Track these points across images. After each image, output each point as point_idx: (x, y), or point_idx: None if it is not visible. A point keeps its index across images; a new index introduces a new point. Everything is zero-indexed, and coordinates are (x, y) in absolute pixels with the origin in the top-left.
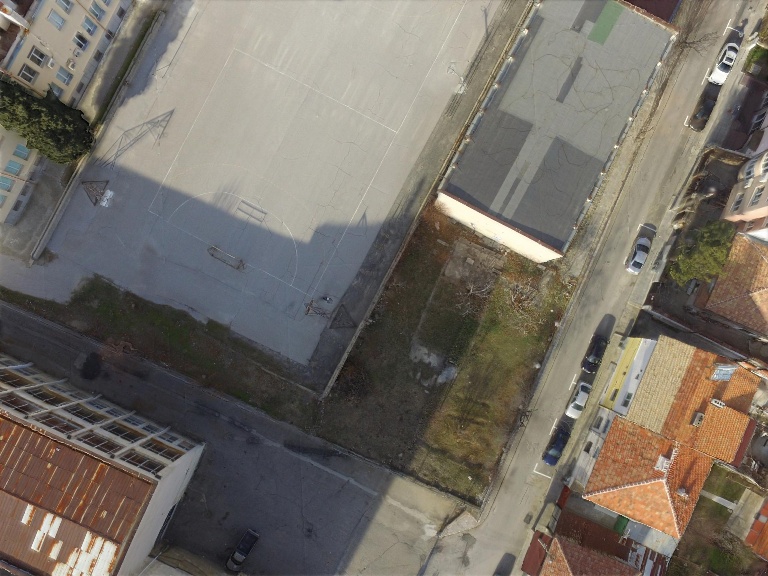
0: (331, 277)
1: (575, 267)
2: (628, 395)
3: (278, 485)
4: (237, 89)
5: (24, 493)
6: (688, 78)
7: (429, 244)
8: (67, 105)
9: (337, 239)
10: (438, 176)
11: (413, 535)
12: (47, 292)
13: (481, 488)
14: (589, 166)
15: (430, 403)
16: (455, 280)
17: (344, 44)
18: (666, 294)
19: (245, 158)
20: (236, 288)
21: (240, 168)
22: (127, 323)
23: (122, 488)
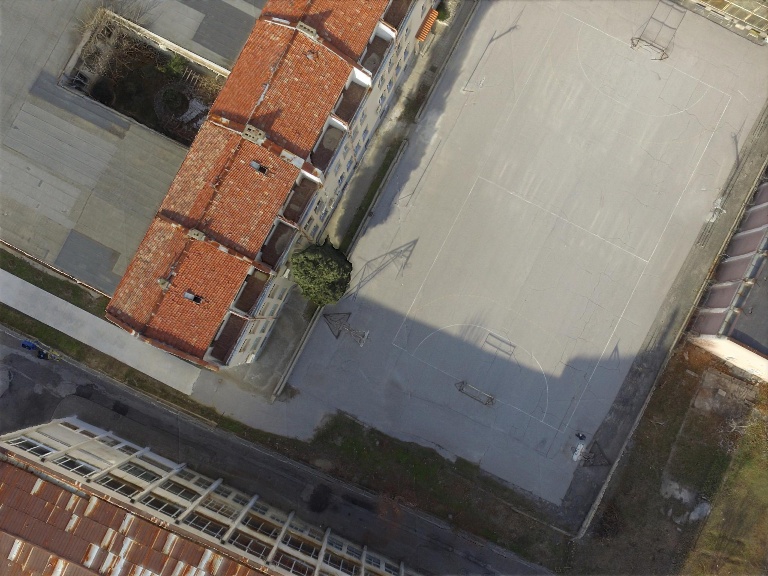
0: (583, 412)
1: None
2: None
3: None
4: (482, 218)
5: None
6: None
7: (677, 374)
8: (316, 239)
9: (589, 373)
10: (692, 307)
11: None
12: (289, 429)
13: None
14: None
15: (683, 541)
16: (705, 412)
17: (591, 172)
18: None
19: (492, 289)
20: (485, 424)
21: (487, 300)
22: (371, 461)
23: None
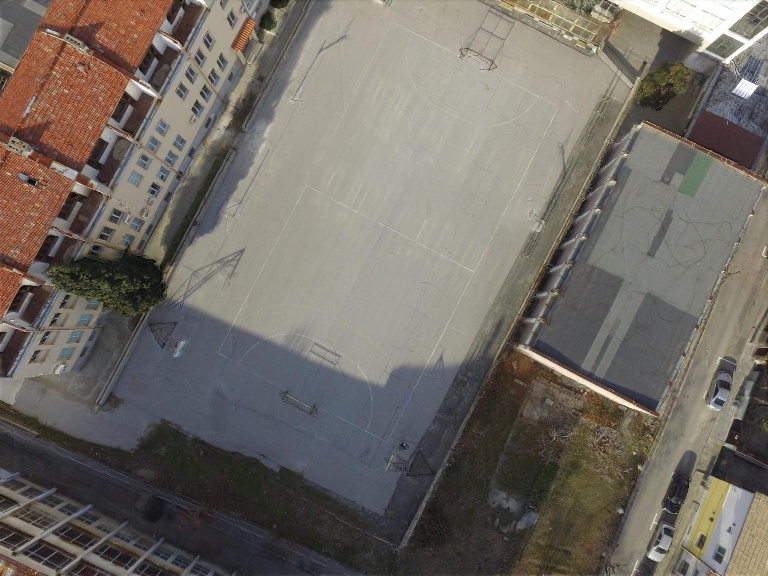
0: (407, 422)
1: None
2: (719, 548)
3: None
4: (309, 228)
5: None
6: (765, 208)
7: (506, 384)
8: (137, 249)
9: (413, 382)
10: (517, 317)
11: None
12: (112, 439)
13: None
14: (682, 322)
15: (509, 551)
16: (533, 421)
17: (419, 181)
18: (748, 430)
19: (318, 299)
20: (309, 434)
21: (313, 309)
22: (195, 471)
23: None
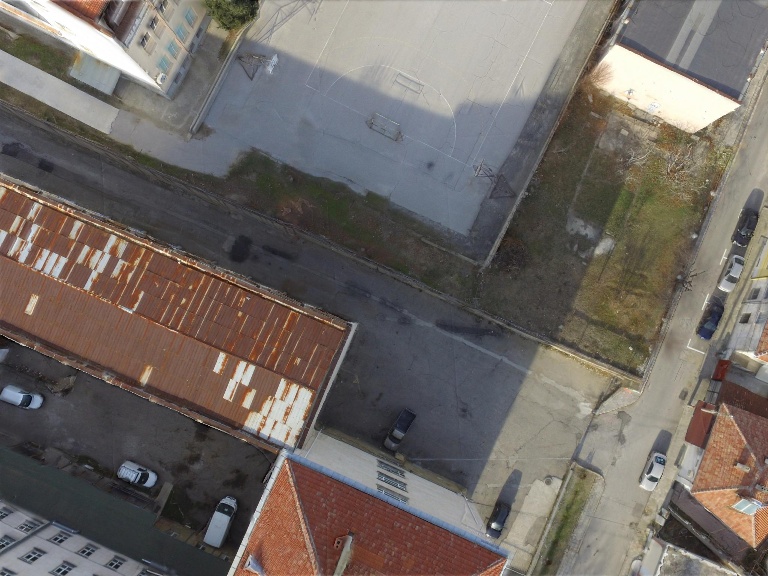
0: (490, 147)
1: (729, 136)
2: None
3: (431, 365)
4: None
5: (216, 342)
6: None
7: (582, 117)
8: None
9: (495, 110)
10: (594, 46)
11: (568, 413)
12: (205, 166)
13: (642, 359)
14: (762, 18)
15: (588, 274)
16: (609, 152)
17: None
18: None
19: (401, 31)
20: (395, 160)
21: (397, 41)
22: (286, 196)
23: (314, 336)
